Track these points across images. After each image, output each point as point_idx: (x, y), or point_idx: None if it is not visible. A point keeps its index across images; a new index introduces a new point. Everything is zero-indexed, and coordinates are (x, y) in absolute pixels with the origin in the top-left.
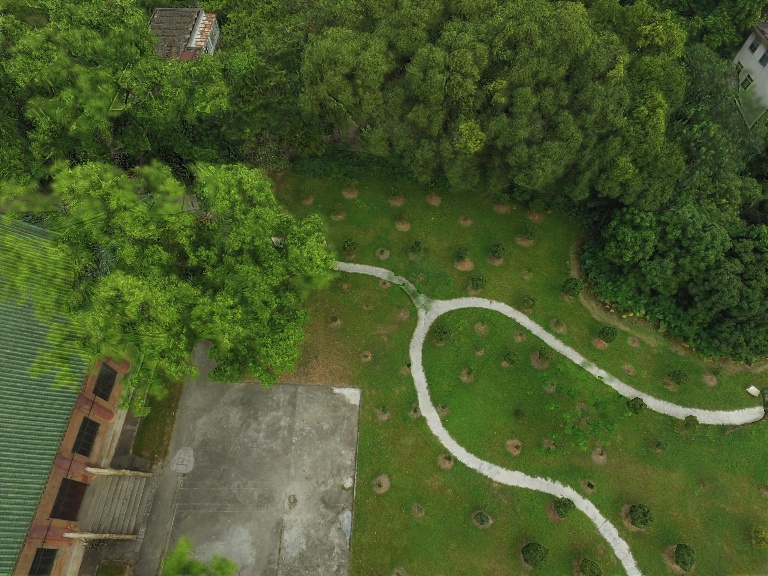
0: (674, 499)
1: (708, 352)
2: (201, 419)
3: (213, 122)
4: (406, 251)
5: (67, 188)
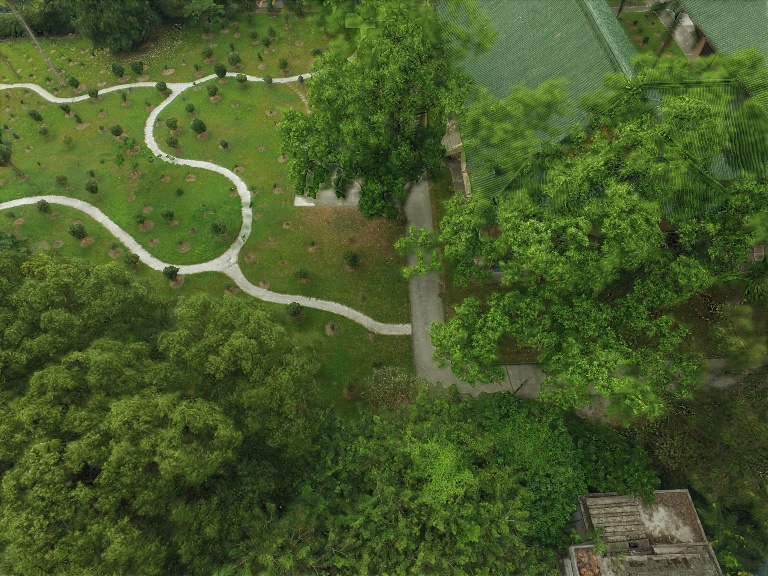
0: None
1: (4, 232)
2: (410, 186)
3: (474, 403)
4: None
5: (677, 397)
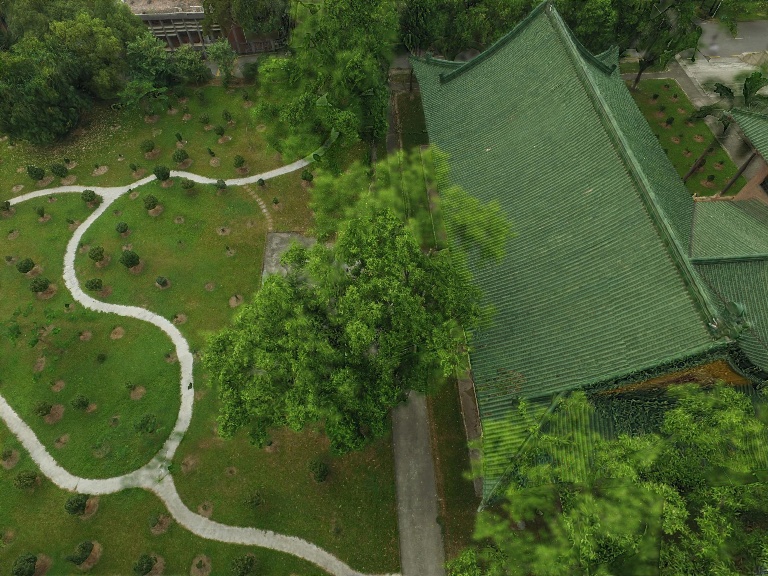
0: (7, 305)
1: None
2: None
3: None
4: (165, 575)
5: None
